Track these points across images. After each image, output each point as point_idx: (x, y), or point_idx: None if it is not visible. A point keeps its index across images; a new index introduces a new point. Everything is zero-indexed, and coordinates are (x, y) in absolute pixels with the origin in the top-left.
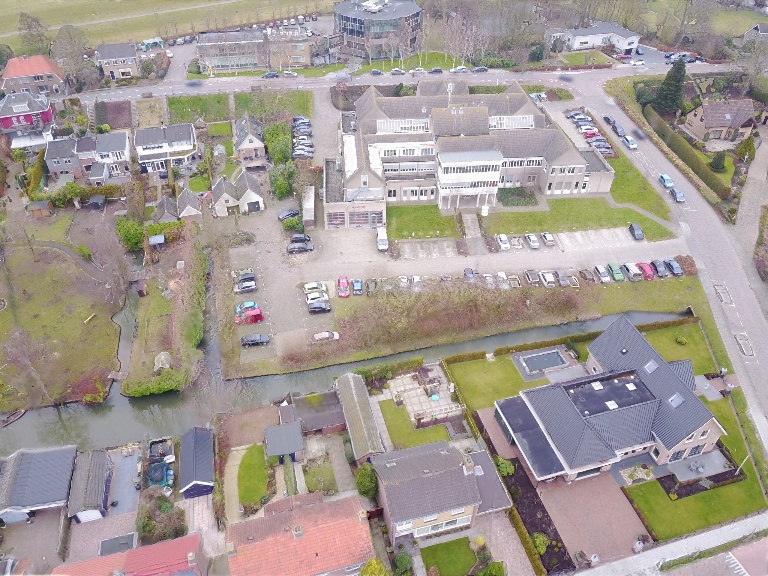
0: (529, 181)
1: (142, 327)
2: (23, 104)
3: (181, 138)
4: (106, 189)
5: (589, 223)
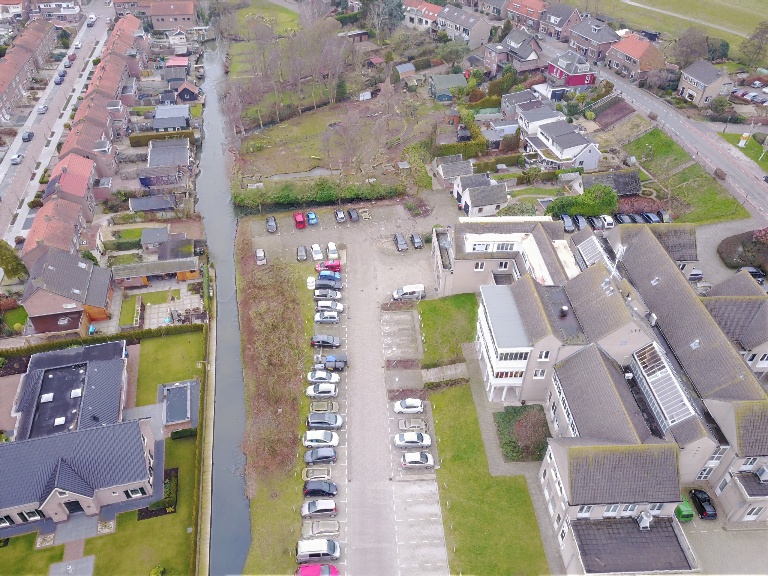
0: None
1: None
2: (565, 61)
3: (562, 144)
4: (473, 131)
5: (461, 530)
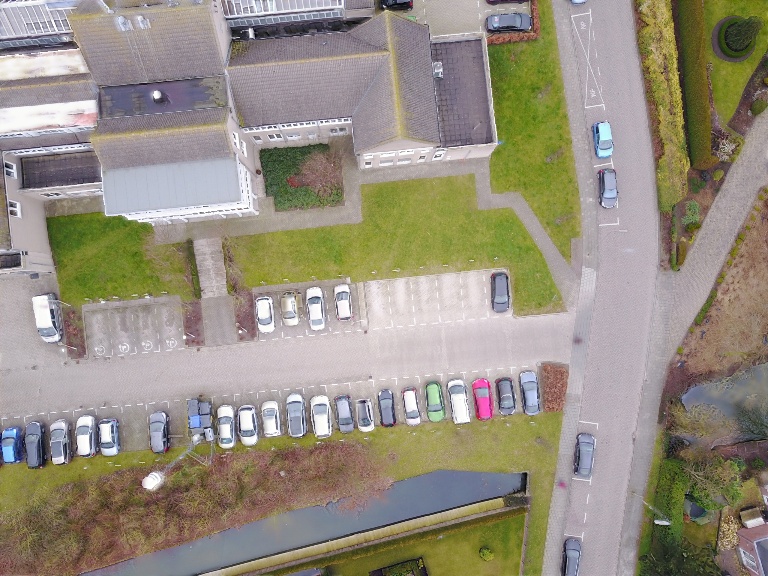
0: (334, 132)
1: None
2: None
3: None
4: None
5: (426, 258)
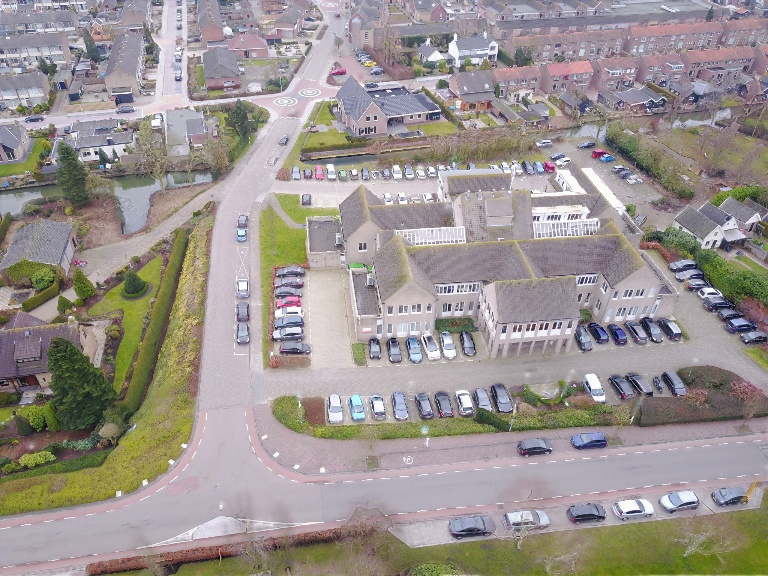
0: None
1: (666, 154)
2: None
3: None
4: None
5: None
